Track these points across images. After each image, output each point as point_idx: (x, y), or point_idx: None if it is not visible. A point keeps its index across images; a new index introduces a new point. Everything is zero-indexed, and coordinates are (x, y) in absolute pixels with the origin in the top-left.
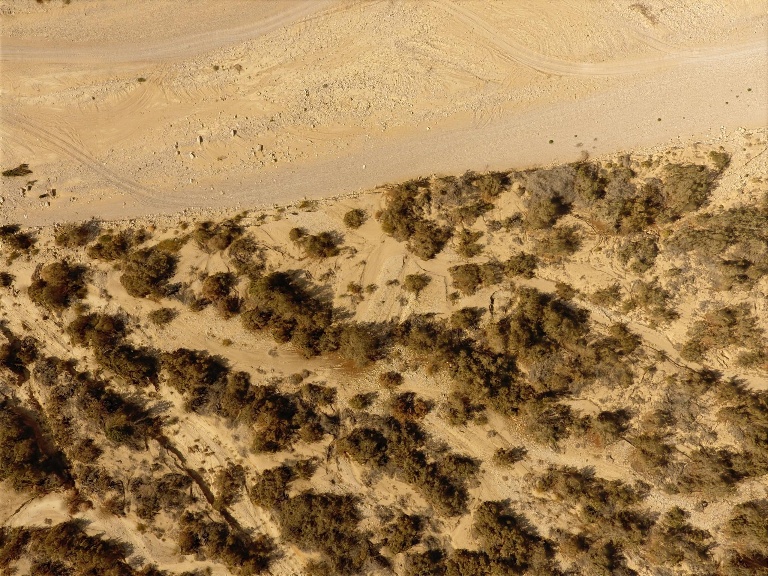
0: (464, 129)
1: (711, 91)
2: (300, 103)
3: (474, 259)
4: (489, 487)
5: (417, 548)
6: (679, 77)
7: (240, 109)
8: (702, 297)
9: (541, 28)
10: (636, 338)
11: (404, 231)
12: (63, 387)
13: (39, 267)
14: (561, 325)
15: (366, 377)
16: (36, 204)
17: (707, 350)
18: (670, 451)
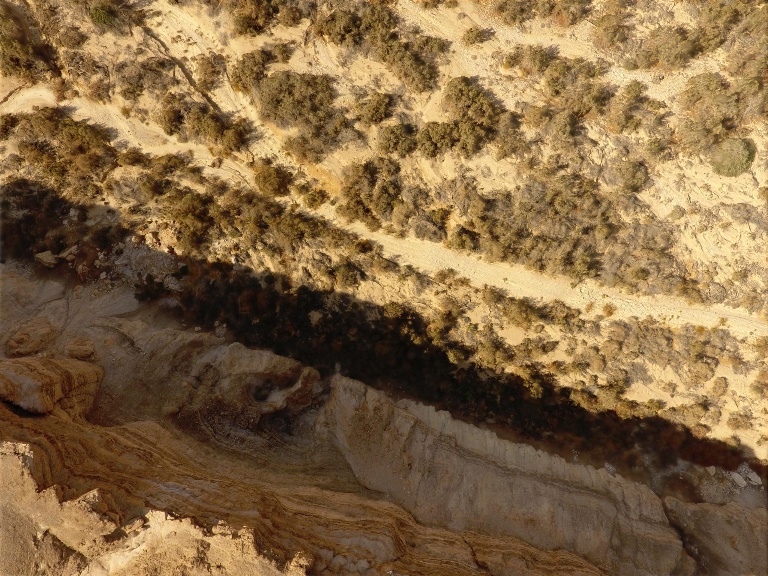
0: None
1: None
2: None
3: None
4: (459, 65)
5: (390, 122)
6: None
7: None
8: None
9: None
10: None
11: None
12: None
13: None
14: None
15: None
16: None
17: None
18: (630, 29)
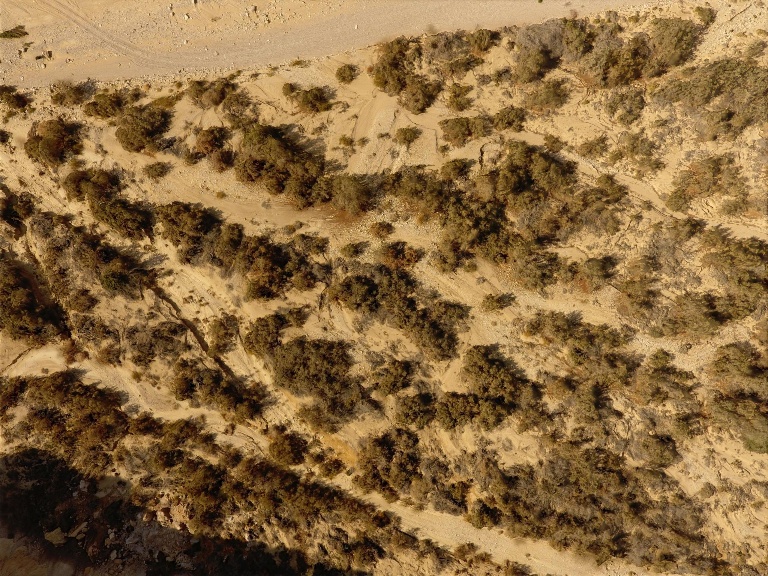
0: None
1: None
2: None
3: (464, 113)
4: (478, 332)
5: (407, 391)
6: None
7: None
8: (687, 147)
9: None
10: (623, 187)
11: (395, 83)
12: (59, 238)
13: (35, 124)
14: (549, 171)
15: (358, 227)
16: (32, 65)
17: (692, 199)
18: (655, 295)
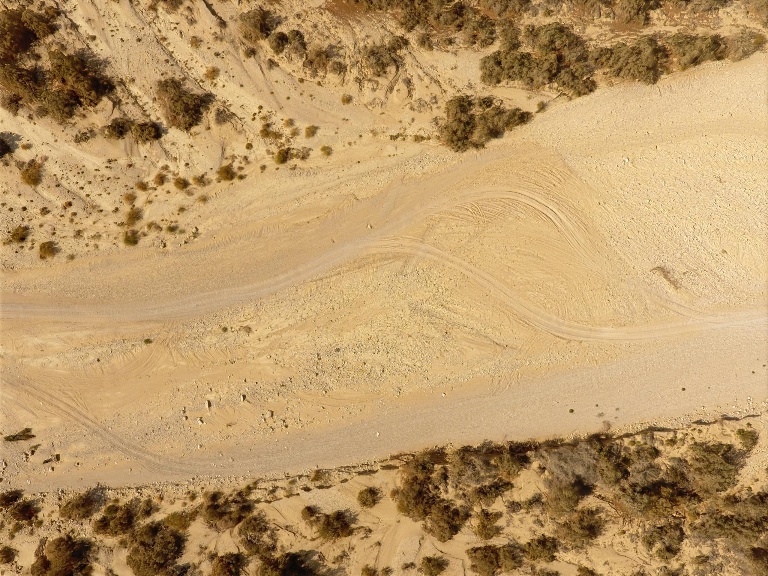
0: (481, 396)
1: (737, 359)
2: (311, 367)
3: (493, 541)
4: None
5: None
6: (703, 344)
7: (249, 373)
8: None
9: (560, 292)
10: None
11: (420, 515)
12: None
13: (43, 542)
14: None
15: None
16: (39, 469)
17: None
18: None
